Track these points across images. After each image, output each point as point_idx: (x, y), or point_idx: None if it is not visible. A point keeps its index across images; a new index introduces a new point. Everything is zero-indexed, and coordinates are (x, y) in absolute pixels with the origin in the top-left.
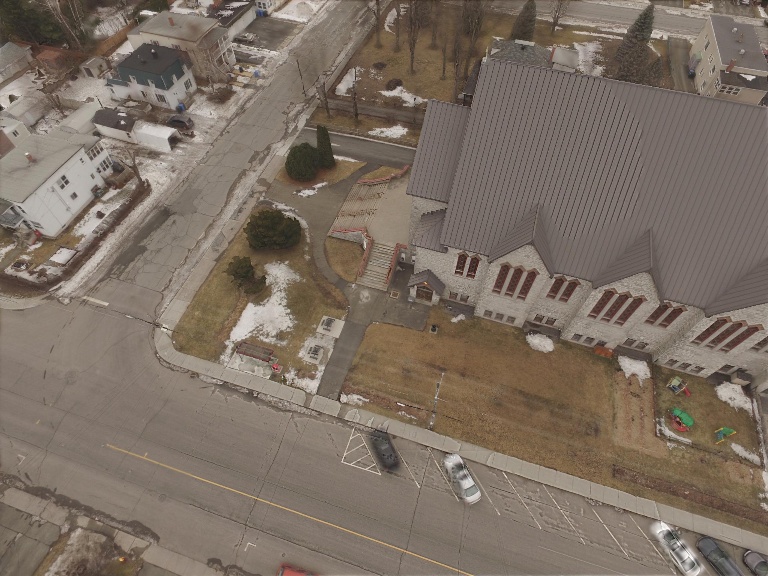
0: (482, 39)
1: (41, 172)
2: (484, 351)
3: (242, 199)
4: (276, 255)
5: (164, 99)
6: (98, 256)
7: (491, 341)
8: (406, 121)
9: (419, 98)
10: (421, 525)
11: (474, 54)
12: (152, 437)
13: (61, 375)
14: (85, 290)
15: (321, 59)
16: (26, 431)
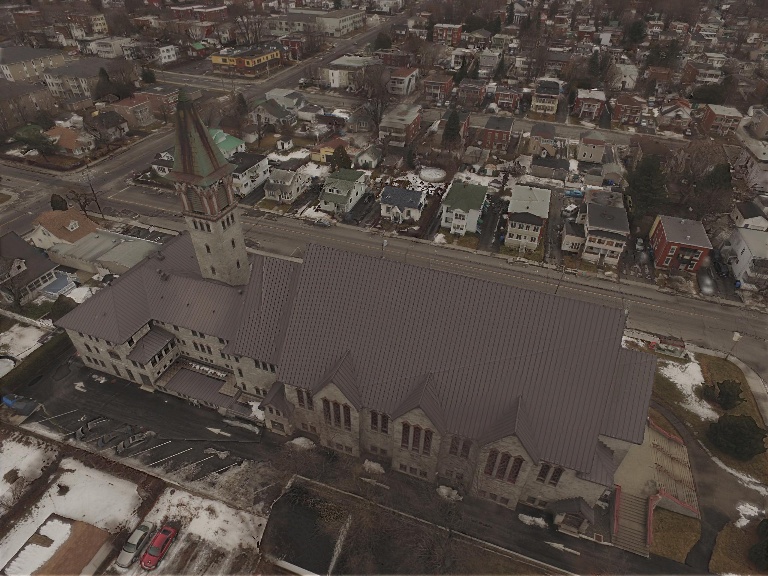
0: None
1: None
2: None
3: None
4: None
5: None
6: None
7: None
8: None
9: None
10: (542, 289)
11: None
12: (696, 320)
13: None
14: None
15: None
16: (767, 325)
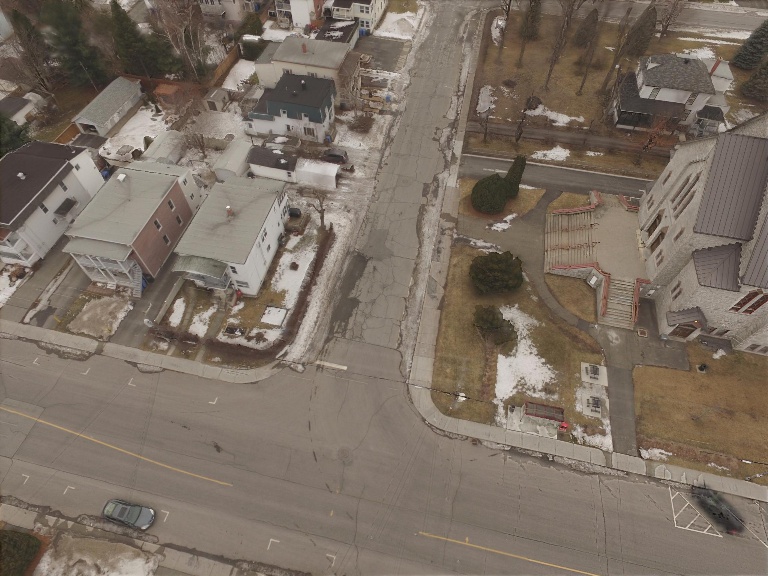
0: (596, 50)
1: (247, 226)
2: (762, 388)
3: (435, 238)
4: (502, 298)
5: (313, 132)
6: (312, 313)
7: (763, 376)
8: (564, 142)
9: (565, 116)
10: None
11: (597, 66)
12: (465, 519)
13: (333, 455)
14: (315, 354)
15: (445, 79)
16: (323, 525)
